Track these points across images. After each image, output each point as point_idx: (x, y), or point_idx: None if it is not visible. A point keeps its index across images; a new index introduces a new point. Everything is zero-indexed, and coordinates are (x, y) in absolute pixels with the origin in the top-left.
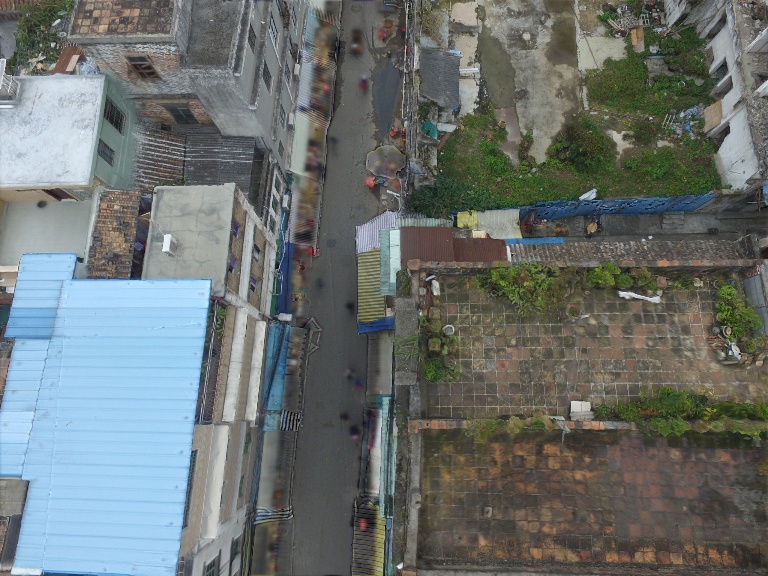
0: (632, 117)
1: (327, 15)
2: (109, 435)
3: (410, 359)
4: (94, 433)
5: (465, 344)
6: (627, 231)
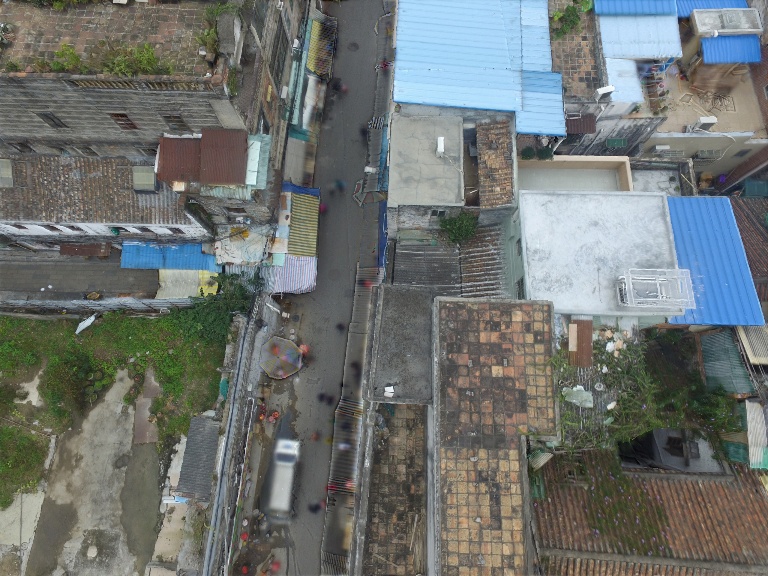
0: (8, 421)
1: (335, 571)
2: (461, 6)
3: (226, 5)
4: (472, 8)
5: (194, 46)
6: (62, 296)
